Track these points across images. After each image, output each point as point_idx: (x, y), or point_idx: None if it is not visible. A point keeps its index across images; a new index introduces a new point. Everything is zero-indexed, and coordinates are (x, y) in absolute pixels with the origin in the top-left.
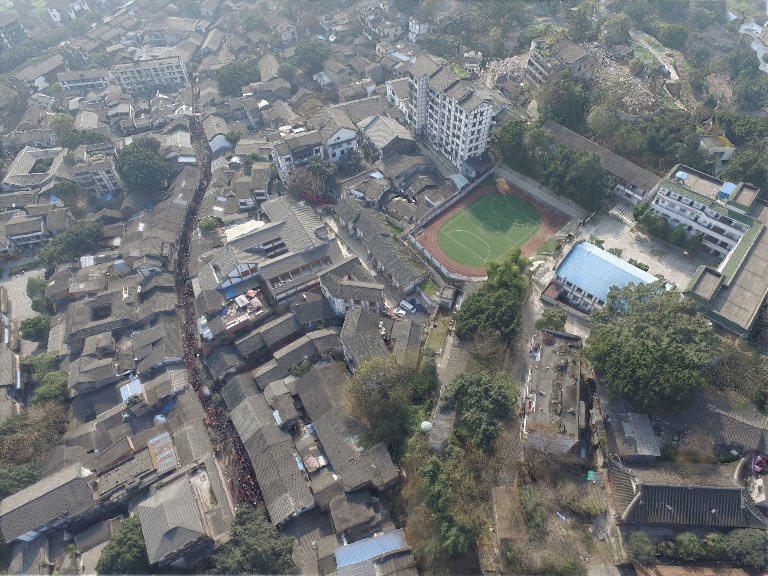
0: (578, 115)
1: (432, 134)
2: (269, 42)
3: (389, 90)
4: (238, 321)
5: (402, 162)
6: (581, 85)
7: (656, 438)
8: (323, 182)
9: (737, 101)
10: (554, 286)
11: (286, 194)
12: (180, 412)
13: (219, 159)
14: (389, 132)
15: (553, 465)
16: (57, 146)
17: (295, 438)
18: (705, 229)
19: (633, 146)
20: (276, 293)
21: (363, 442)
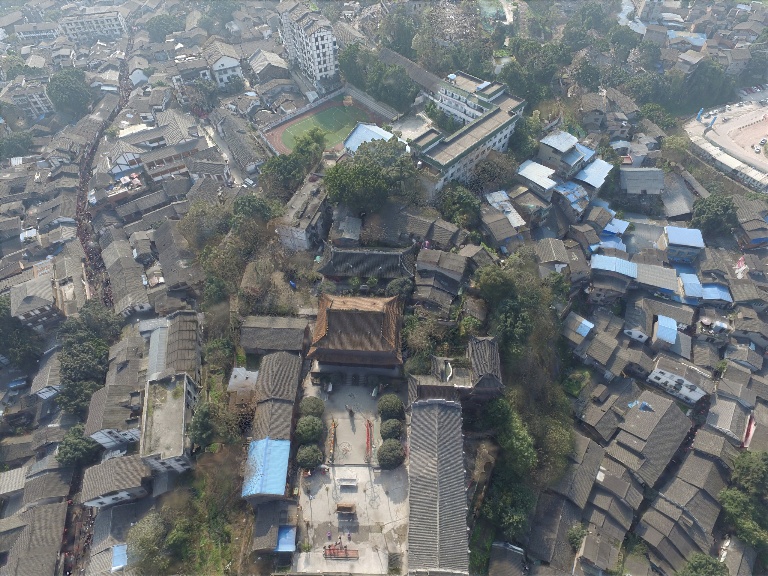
0: (411, 44)
1: (298, 62)
2: (197, 0)
3: (279, 33)
4: (118, 192)
5: (270, 83)
6: (411, 19)
7: (361, 231)
8: (204, 97)
9: (562, 41)
10: (345, 157)
11: (176, 108)
12: (66, 253)
13: (137, 89)
14: (265, 61)
15: (297, 256)
16: (7, 81)
17: (147, 268)
18: (469, 118)
19: (435, 62)
20: (151, 174)
21: (190, 264)
